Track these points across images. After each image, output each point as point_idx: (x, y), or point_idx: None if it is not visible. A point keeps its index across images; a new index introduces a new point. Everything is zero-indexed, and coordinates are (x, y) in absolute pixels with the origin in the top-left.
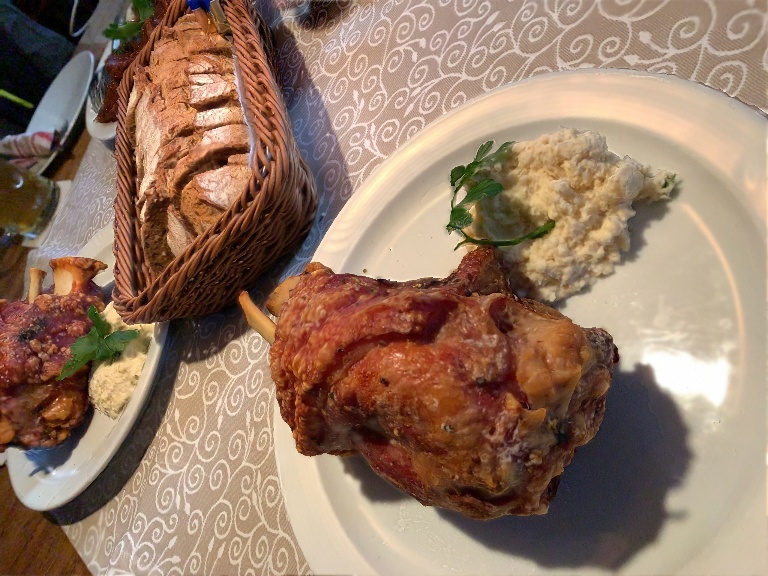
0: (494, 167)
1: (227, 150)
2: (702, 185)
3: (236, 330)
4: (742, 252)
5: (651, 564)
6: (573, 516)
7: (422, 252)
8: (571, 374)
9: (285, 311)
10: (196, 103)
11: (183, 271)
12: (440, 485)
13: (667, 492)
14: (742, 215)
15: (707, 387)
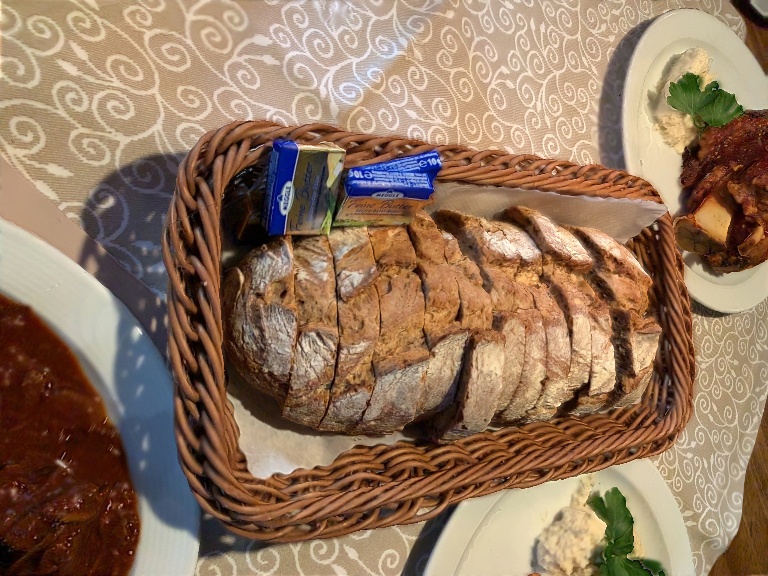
0: None
1: None
2: None
3: None
4: None
5: None
6: None
7: None
8: None
9: None
10: None
11: None
12: None
13: None
14: None
15: None
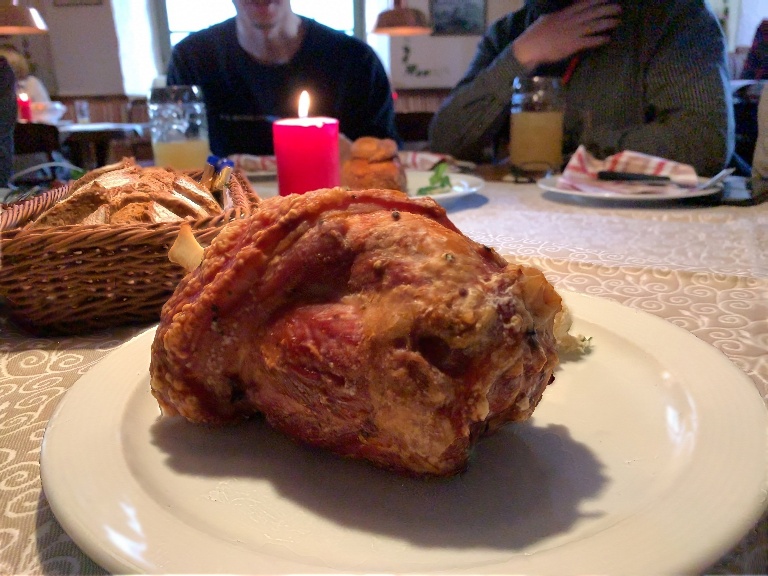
0: None
1: (190, 212)
2: (612, 347)
3: (53, 344)
4: (646, 378)
5: (568, 540)
6: (468, 508)
7: None
8: (556, 294)
9: None
10: (180, 185)
11: (89, 231)
12: (396, 327)
13: (582, 500)
14: (646, 359)
15: (619, 444)
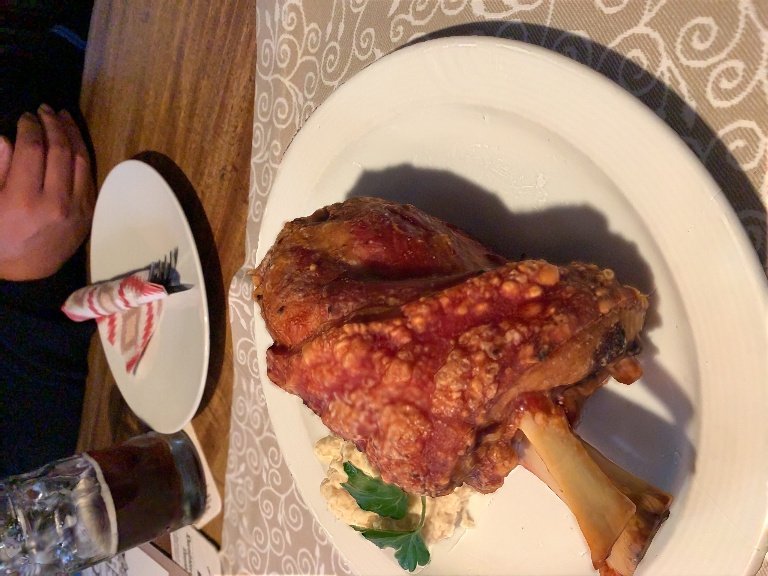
0: (378, 526)
1: None
2: (316, 425)
3: None
4: None
5: (343, 179)
6: None
7: (543, 520)
8: None
9: (390, 440)
10: None
11: None
12: None
13: None
14: None
15: None
